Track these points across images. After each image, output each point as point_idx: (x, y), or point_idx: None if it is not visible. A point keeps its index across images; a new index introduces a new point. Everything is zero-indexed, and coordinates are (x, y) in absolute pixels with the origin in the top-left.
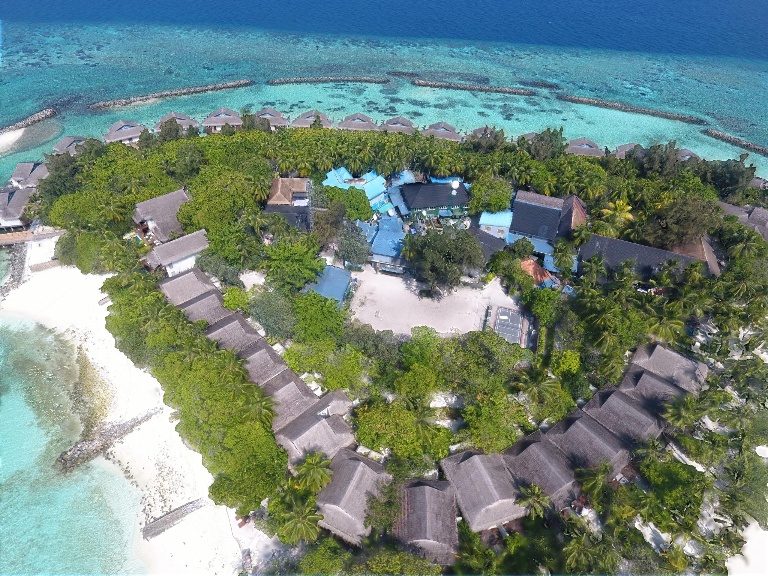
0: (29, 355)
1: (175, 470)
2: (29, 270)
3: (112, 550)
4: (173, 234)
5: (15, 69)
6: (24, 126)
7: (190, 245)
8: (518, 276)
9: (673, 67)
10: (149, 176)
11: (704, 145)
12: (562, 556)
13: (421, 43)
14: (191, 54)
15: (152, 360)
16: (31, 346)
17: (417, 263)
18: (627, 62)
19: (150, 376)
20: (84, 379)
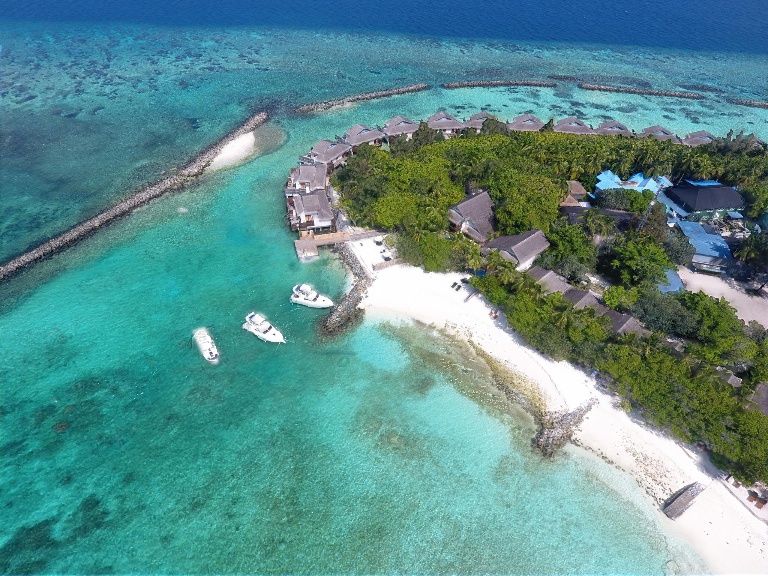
0: (429, 349)
1: (649, 456)
2: (370, 269)
3: (646, 528)
4: (488, 235)
5: (196, 73)
6: (251, 130)
7: (535, 245)
8: None
9: None
10: (438, 179)
11: None
12: None
13: (557, 47)
14: (348, 58)
15: (588, 353)
16: (424, 340)
17: (763, 263)
18: None
19: (565, 369)
20: (498, 371)
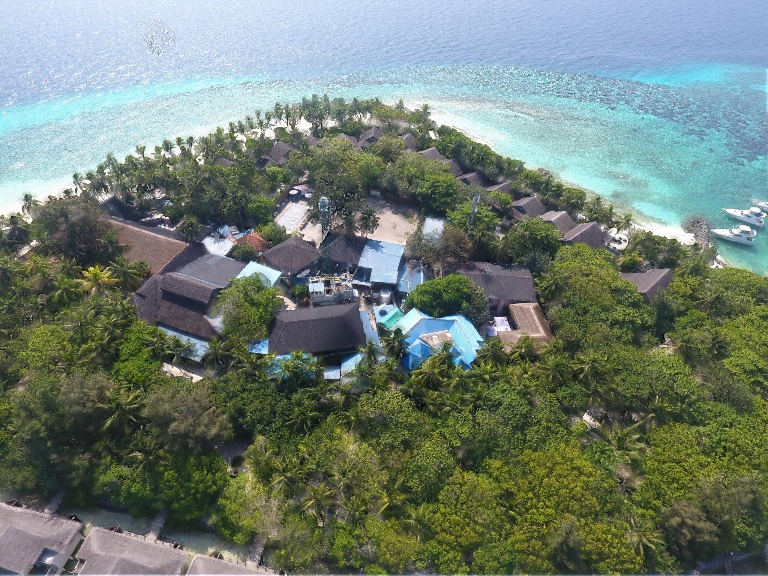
0: (623, 210)
1: None
2: None
3: None
4: None
5: None
6: None
7: None
8: (271, 224)
9: None
10: None
11: None
12: (320, 131)
13: None
14: None
15: None
16: None
17: None
18: None
19: None
20: None
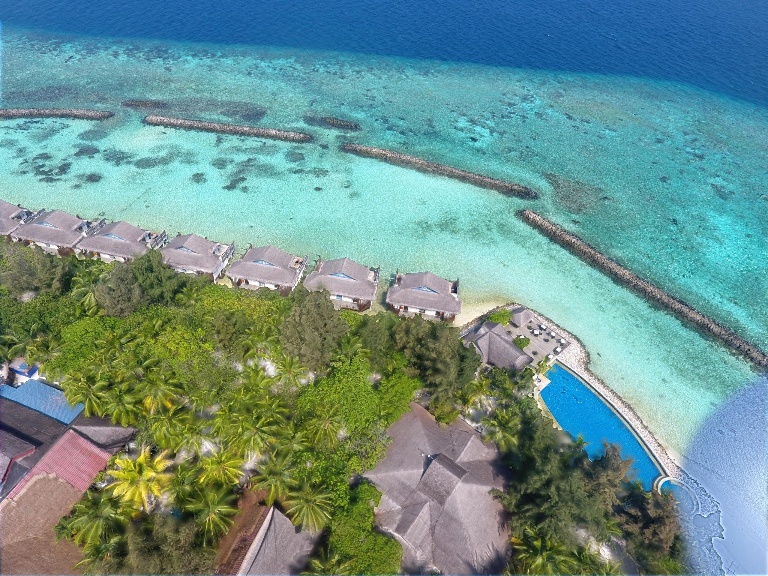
0: None
1: None
2: None
3: None
4: None
5: None
6: None
7: None
8: None
9: (546, 93)
10: None
11: (505, 241)
12: None
13: (224, 53)
14: None
15: None
16: None
17: None
18: (487, 84)
19: None
20: None
